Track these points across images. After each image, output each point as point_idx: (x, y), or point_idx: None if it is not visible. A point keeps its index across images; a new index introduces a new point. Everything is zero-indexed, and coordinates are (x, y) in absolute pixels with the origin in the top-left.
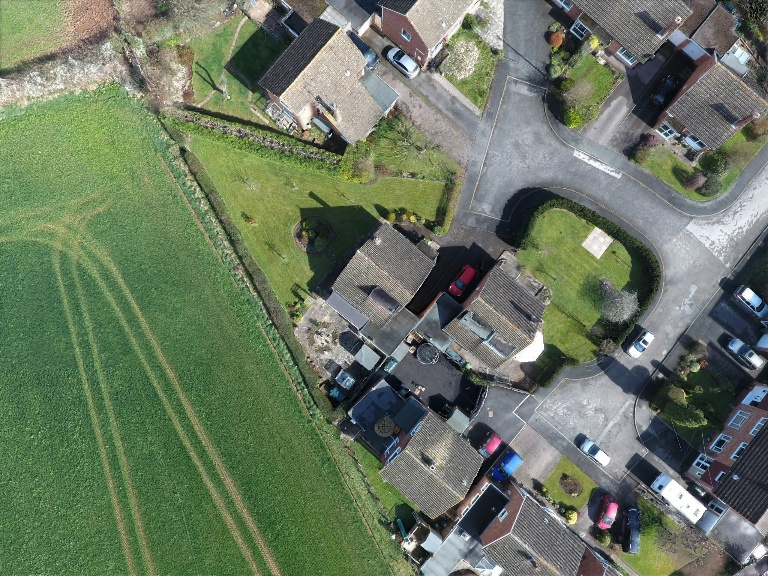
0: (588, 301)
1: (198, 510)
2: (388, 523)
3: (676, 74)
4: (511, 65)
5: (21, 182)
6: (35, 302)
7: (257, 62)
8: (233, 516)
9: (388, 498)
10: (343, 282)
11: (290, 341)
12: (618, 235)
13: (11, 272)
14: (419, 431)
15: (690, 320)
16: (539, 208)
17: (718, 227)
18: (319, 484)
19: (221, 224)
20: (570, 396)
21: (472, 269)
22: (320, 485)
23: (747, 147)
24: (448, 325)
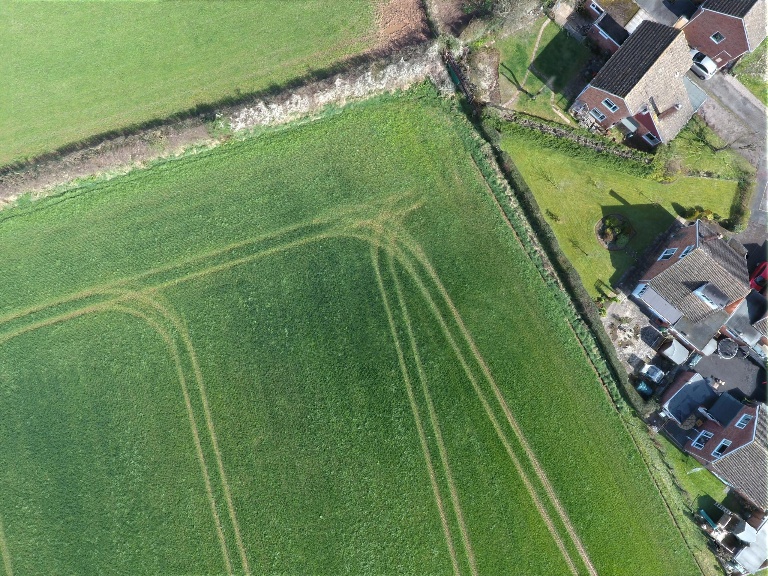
0: None
1: (515, 500)
2: (692, 514)
3: None
4: None
5: (341, 180)
6: (357, 296)
7: (559, 63)
8: (547, 506)
9: (691, 489)
10: (665, 278)
11: (603, 335)
12: None
13: (334, 267)
14: (759, 423)
15: None
16: None
17: None
18: (626, 475)
19: (529, 221)
20: None
21: None
22: (627, 476)
23: None
24: (762, 320)
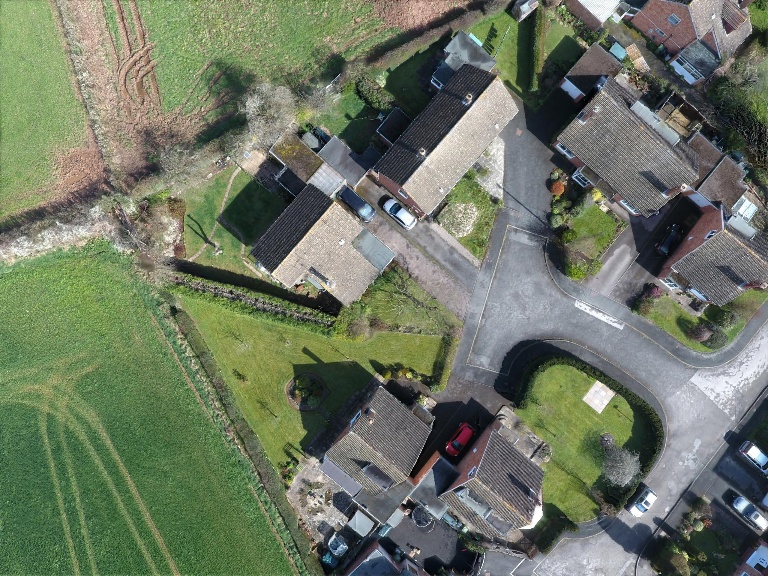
0: (589, 457)
1: None
2: None
3: (681, 221)
4: (511, 214)
5: (8, 343)
6: (21, 467)
7: (250, 214)
8: None
9: None
10: (336, 452)
11: (282, 507)
12: (620, 393)
13: None
14: None
15: (694, 475)
16: (539, 368)
17: (723, 379)
18: None
19: (212, 383)
20: (569, 556)
21: (469, 430)
22: None
23: (754, 296)
24: (444, 494)
